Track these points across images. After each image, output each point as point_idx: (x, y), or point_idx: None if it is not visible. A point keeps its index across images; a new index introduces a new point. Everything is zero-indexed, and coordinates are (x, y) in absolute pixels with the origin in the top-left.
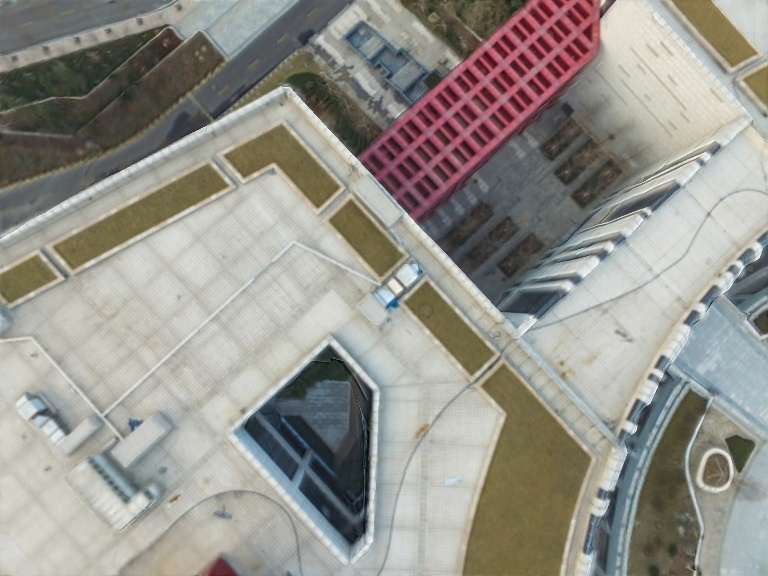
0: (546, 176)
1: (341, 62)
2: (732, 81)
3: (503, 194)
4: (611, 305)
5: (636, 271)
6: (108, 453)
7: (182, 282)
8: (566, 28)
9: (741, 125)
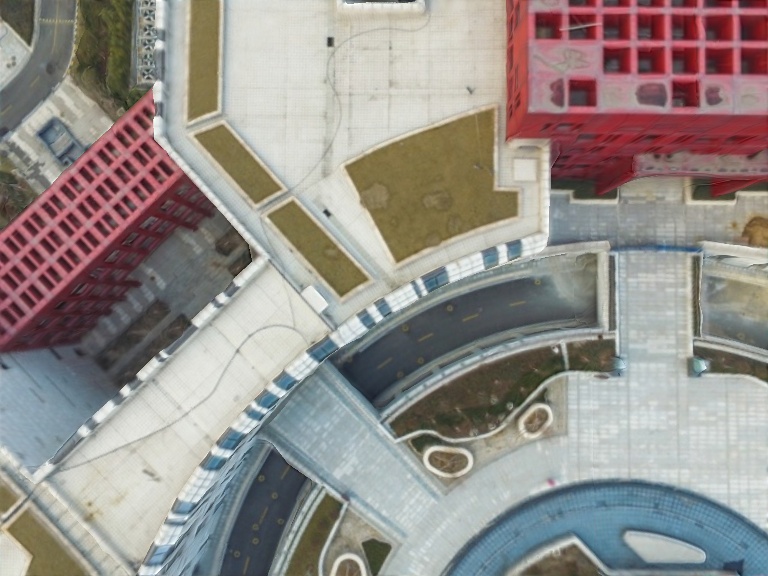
0: (221, 272)
1: (35, 159)
2: (259, 217)
3: (179, 291)
4: (139, 445)
5: (165, 410)
6: None
7: None
8: (151, 151)
9: (256, 264)
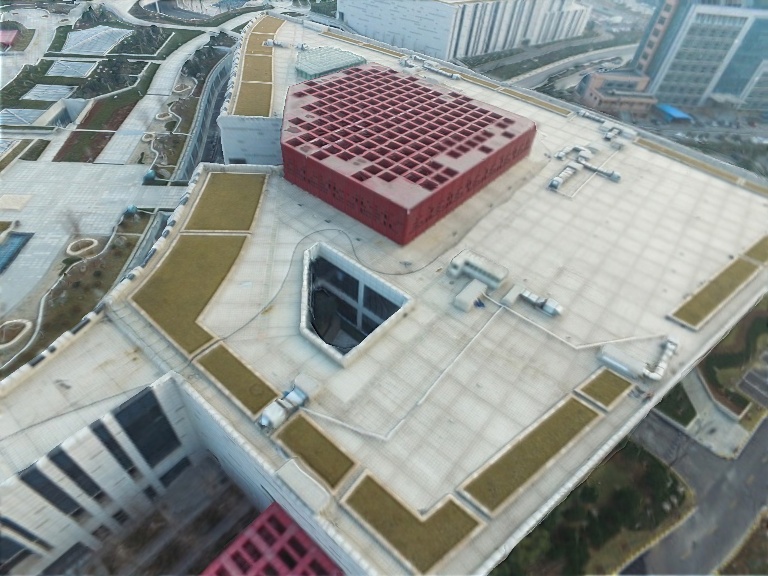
0: None
1: None
2: None
3: None
4: (65, 410)
5: (20, 446)
6: (490, 287)
7: (479, 397)
8: None
9: None
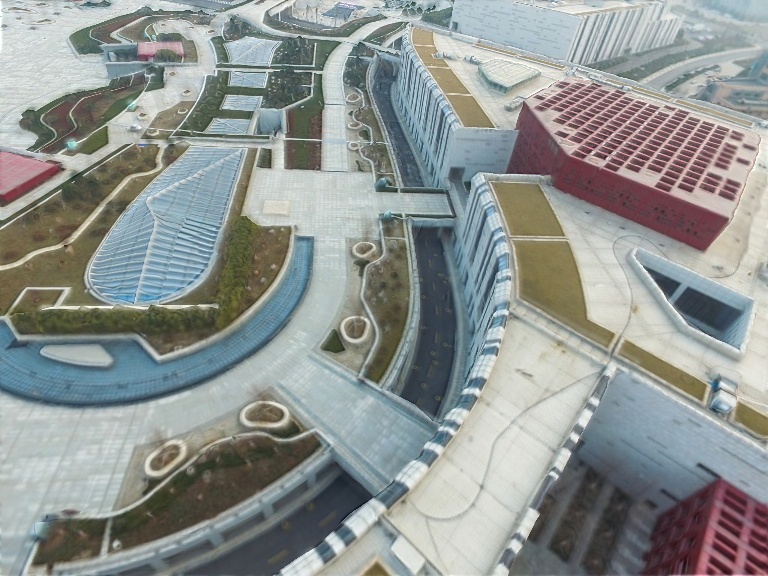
0: None
1: None
2: None
3: None
4: (544, 395)
5: (533, 425)
6: None
7: None
8: None
9: None
